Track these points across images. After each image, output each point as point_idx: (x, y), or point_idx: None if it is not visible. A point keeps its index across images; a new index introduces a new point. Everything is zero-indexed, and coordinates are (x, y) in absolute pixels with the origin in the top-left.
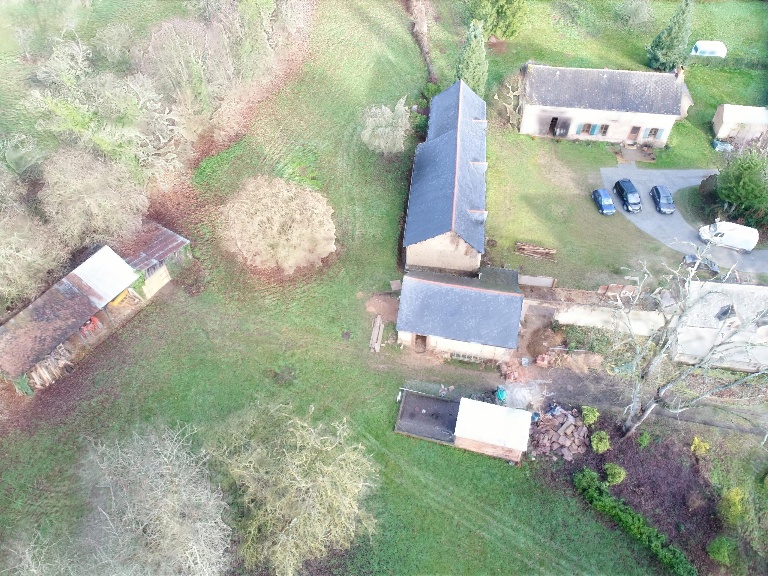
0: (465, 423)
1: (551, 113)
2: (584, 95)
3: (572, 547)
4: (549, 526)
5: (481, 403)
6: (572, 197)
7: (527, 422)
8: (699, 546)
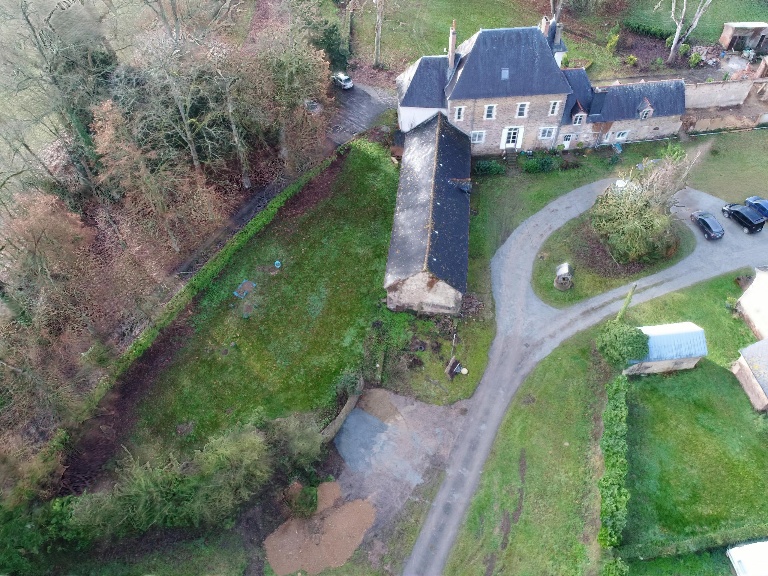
0: (762, 23)
1: None
2: None
3: None
4: None
5: (762, 26)
6: None
7: (733, 25)
8: None
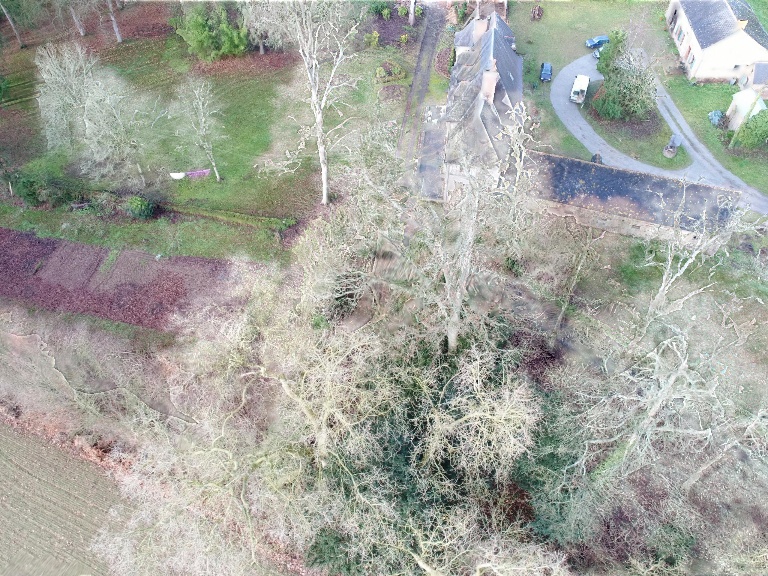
0: None
1: (677, 4)
2: (695, 2)
3: (356, 6)
4: (364, 1)
5: None
6: (600, 33)
7: None
8: (357, 37)
